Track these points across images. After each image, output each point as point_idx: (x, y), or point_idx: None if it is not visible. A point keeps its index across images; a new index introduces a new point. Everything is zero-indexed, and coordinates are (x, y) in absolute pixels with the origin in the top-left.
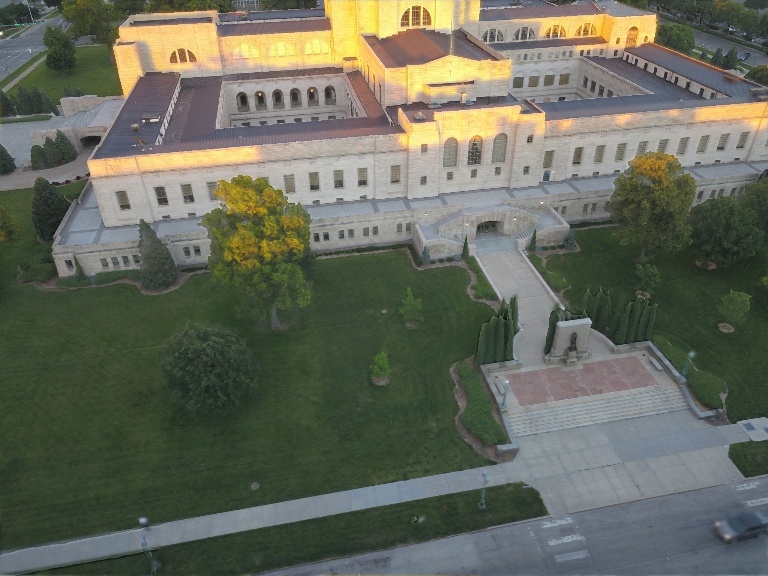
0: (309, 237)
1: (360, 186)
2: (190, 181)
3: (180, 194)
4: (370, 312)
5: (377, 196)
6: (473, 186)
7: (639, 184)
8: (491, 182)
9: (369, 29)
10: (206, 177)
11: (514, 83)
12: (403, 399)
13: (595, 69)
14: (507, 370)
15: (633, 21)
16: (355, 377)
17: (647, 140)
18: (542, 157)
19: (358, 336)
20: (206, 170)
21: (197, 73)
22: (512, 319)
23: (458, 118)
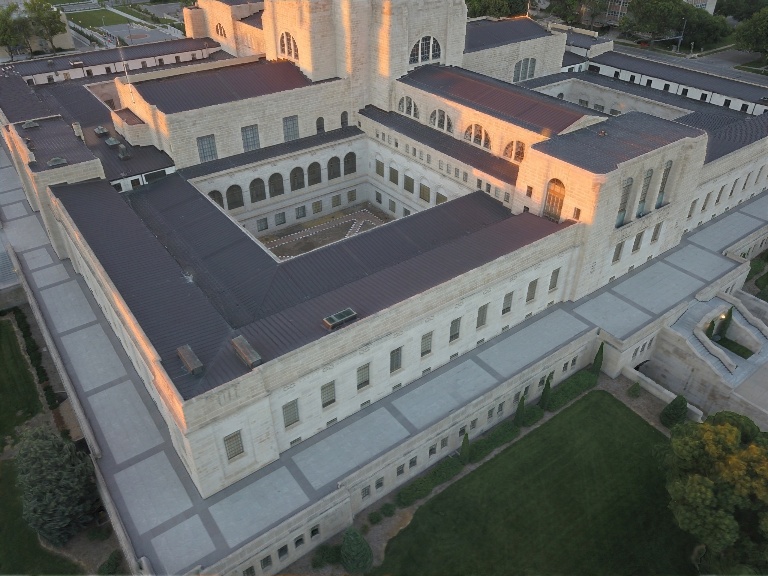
0: None
1: None
2: None
3: None
4: None
5: None
6: None
7: None
8: None
9: None
10: None
11: (407, 182)
12: None
13: None
14: None
15: (555, 167)
16: None
17: None
18: None
19: None
20: None
21: (227, 49)
22: None
23: None
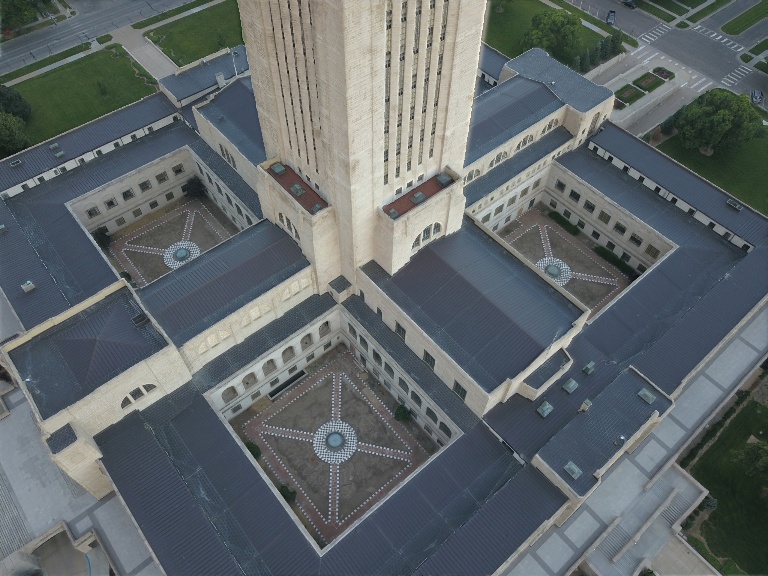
0: None
1: None
2: None
3: None
4: None
5: None
6: None
7: None
8: None
9: (367, 257)
10: None
11: (494, 212)
12: None
13: (579, 184)
14: None
15: (597, 109)
16: None
17: None
18: None
19: None
20: None
21: (159, 395)
22: None
23: None
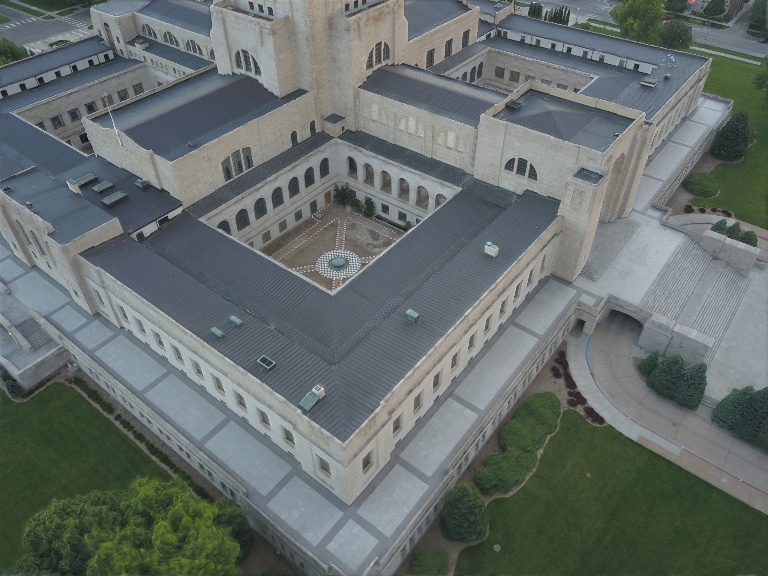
0: None
1: None
2: None
3: None
4: None
5: None
6: None
7: None
8: None
9: None
10: None
11: None
12: None
13: None
14: None
15: None
16: None
17: None
18: None
19: None
20: None
21: None
22: None
23: None
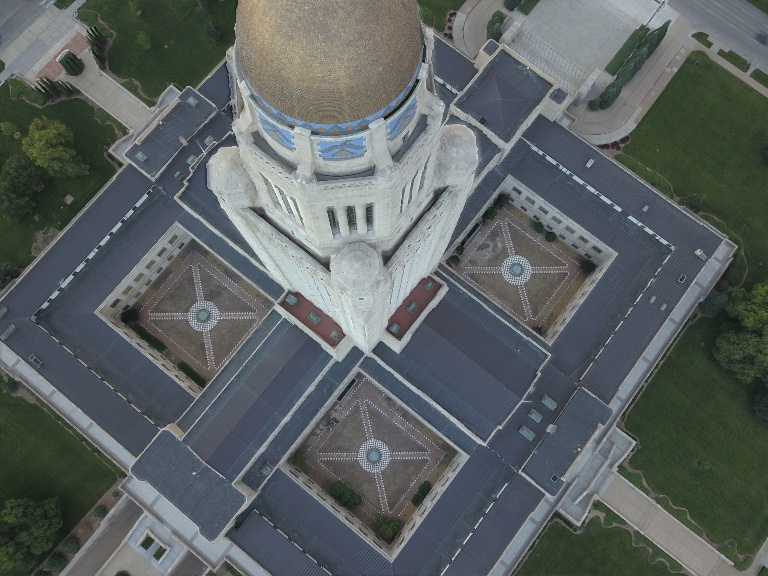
0: None
1: None
2: None
3: None
4: (171, 42)
5: None
6: None
7: None
8: None
9: None
10: None
11: None
12: None
13: None
14: None
15: None
16: (147, 5)
17: None
18: None
19: (164, 25)
20: None
21: None
22: None
23: None
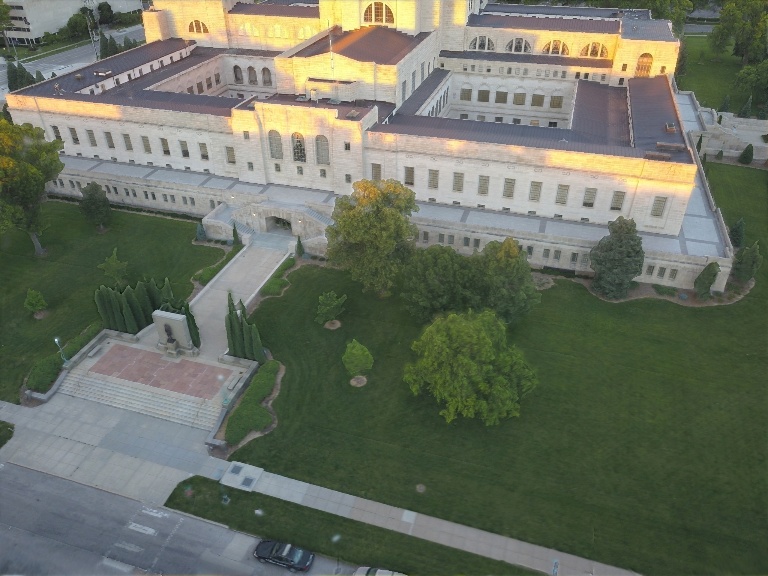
0: (32, 181)
1: (203, 160)
2: (74, 126)
3: (69, 135)
4: None
5: (216, 172)
6: (301, 183)
7: (348, 208)
8: (318, 183)
9: None
10: (84, 125)
11: (497, 97)
12: (32, 333)
13: None
14: (122, 341)
15: (645, 46)
16: None
17: (488, 175)
18: (368, 169)
19: (75, 278)
20: (83, 119)
21: (209, 43)
22: (155, 299)
23: (277, 112)
